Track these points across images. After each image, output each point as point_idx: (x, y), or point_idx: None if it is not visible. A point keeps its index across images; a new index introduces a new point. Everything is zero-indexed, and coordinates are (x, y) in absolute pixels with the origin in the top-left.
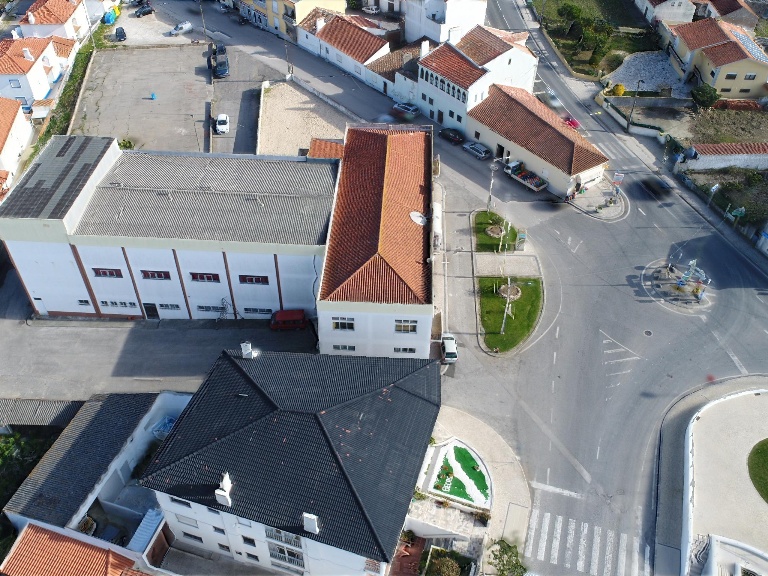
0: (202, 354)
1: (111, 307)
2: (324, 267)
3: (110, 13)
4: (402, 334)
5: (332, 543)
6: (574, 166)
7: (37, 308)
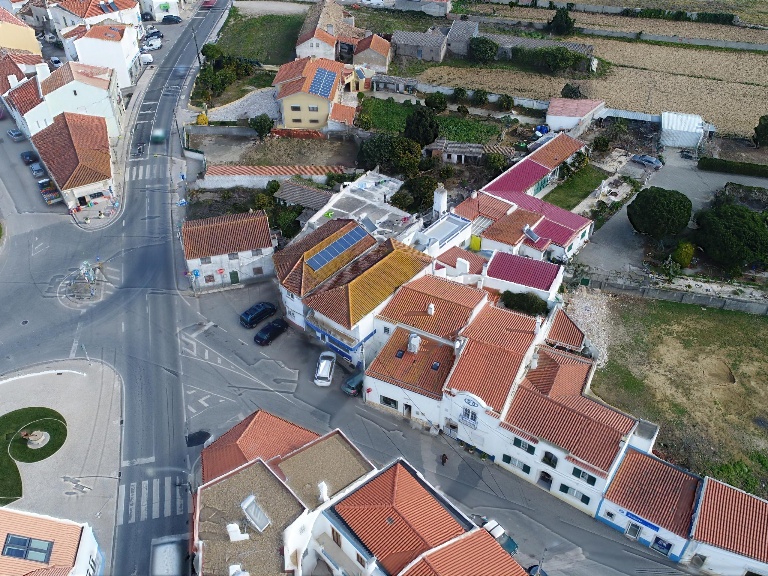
0: None
1: None
2: None
3: None
4: None
5: None
6: (69, 182)
7: None
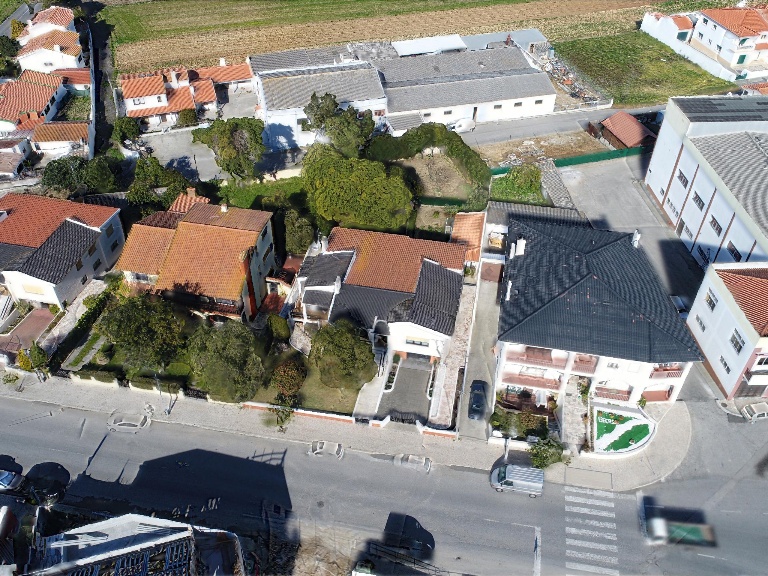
0: (659, 265)
1: (669, 206)
2: (760, 267)
3: None
4: (732, 346)
5: (502, 309)
6: None
7: (647, 177)
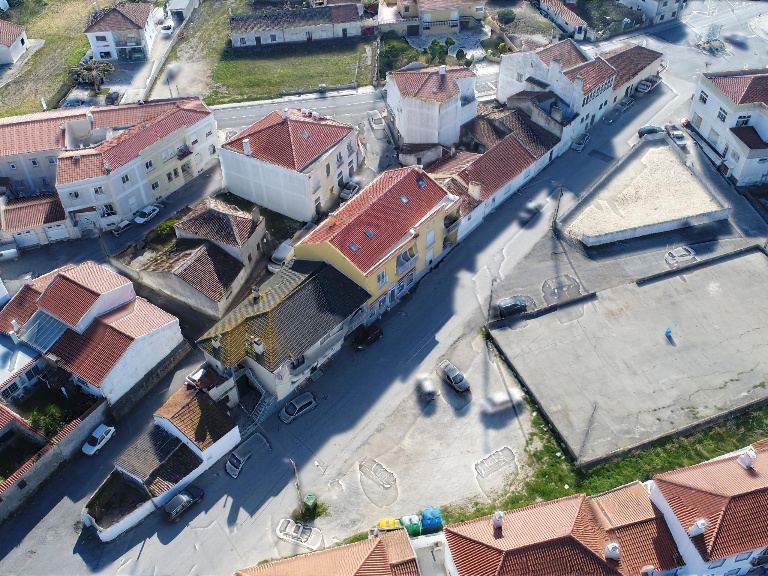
0: None
1: None
2: None
3: (422, 515)
4: None
5: None
6: None
7: None
